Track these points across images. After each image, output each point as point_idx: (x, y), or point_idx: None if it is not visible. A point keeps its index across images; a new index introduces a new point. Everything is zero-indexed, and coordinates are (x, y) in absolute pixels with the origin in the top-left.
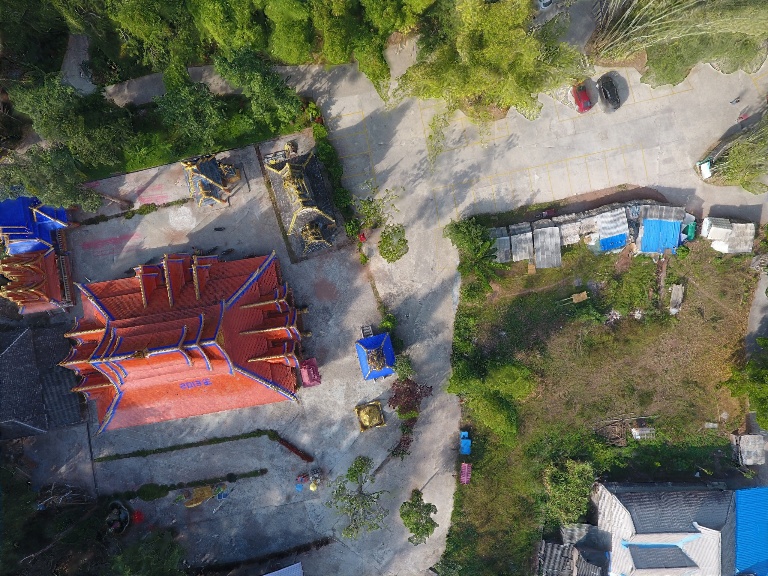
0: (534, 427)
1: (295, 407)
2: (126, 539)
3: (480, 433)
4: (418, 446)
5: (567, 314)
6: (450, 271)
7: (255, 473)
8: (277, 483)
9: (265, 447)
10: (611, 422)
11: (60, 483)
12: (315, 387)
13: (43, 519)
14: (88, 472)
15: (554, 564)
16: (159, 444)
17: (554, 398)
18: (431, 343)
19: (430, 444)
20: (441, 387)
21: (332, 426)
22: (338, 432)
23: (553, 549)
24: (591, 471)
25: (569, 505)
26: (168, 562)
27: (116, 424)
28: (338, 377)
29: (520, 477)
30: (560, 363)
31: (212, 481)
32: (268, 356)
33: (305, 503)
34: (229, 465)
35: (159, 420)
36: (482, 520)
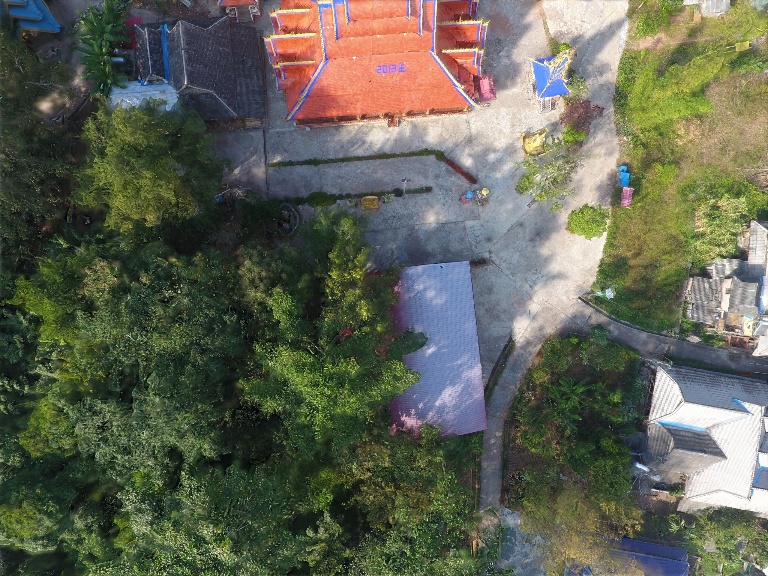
0: (688, 169)
1: (463, 131)
2: (292, 243)
3: (637, 170)
4: (576, 179)
5: (727, 64)
6: (618, 15)
7: (420, 190)
8: (440, 202)
9: (431, 166)
10: (762, 171)
11: (233, 184)
12: (483, 114)
13: (220, 209)
14: (261, 175)
15: (702, 296)
16: (331, 155)
17: (709, 144)
18: (595, 82)
19: (588, 178)
20: (602, 125)
21: (496, 152)
22: (502, 158)
23: (702, 282)
24: (745, 207)
25: (721, 240)
26: (361, 222)
27: (304, 112)
28: (505, 106)
29: (672, 215)
30: (717, 111)
31: (379, 194)
32: (461, 49)
33: (466, 223)
34: (396, 180)
35: (345, 113)
36: (635, 250)
